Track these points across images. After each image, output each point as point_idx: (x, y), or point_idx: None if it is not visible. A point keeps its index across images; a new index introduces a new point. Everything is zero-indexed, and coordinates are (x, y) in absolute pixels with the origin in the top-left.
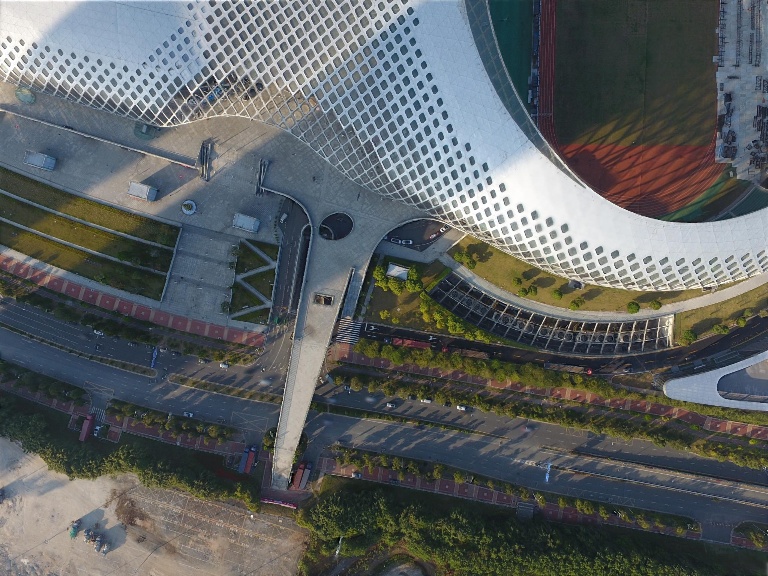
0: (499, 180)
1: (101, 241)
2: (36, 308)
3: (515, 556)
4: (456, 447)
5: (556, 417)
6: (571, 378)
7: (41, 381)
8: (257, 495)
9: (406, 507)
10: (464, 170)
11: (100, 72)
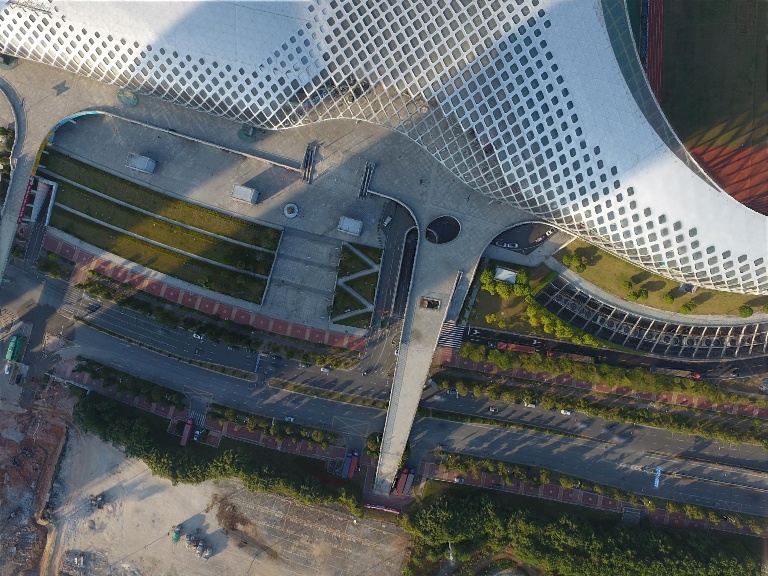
0: (628, 184)
1: (201, 244)
2: (134, 312)
3: (628, 562)
4: (560, 452)
5: (663, 422)
6: (681, 382)
7: (142, 385)
8: (361, 500)
9: (514, 512)
10: (590, 174)
11: (215, 74)
